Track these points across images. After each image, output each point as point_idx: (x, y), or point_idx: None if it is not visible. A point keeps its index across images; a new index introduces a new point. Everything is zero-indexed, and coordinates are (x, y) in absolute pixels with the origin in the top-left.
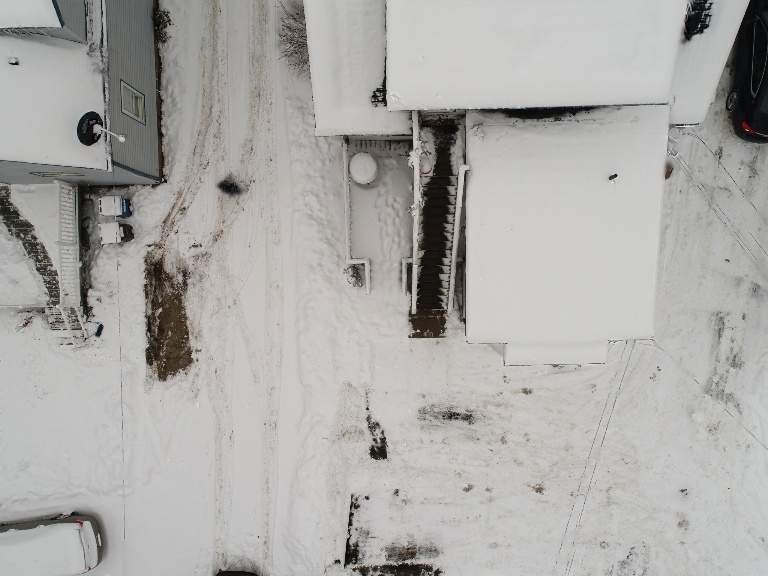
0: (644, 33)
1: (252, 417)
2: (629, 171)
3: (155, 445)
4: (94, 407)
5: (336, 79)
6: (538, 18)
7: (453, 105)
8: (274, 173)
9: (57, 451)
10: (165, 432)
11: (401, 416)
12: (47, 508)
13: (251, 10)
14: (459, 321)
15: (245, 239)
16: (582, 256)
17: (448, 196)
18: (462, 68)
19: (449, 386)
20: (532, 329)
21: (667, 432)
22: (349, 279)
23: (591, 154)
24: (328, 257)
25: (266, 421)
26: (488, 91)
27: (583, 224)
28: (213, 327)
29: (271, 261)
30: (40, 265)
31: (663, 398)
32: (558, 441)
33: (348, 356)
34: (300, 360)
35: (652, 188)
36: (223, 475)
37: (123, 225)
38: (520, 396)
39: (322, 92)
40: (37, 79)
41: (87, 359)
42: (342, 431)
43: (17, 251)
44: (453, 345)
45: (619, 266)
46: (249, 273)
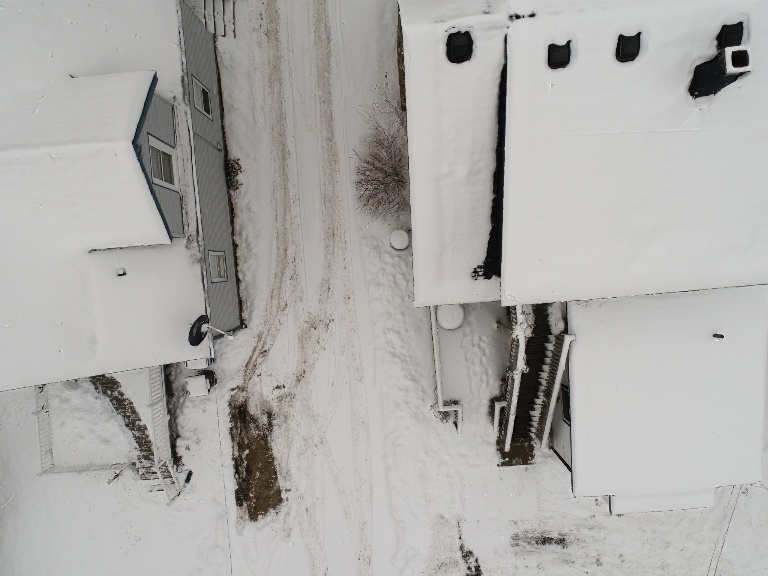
0: (761, 224)
1: (346, 553)
2: (734, 329)
3: None
4: (187, 551)
5: (439, 262)
6: (655, 218)
7: (568, 299)
8: (353, 311)
9: None
10: (260, 573)
11: (494, 544)
12: None
13: (320, 151)
14: (548, 449)
15: (328, 378)
16: (688, 410)
17: (544, 350)
18: (579, 267)
19: (541, 512)
20: (639, 481)
21: (762, 545)
22: (436, 415)
23: (694, 314)
24: (413, 393)
25: (360, 556)
26: (604, 285)
27: (688, 380)
28: (301, 467)
29: (355, 398)
30: (128, 420)
31: (756, 512)
32: (653, 560)
33: (438, 488)
34: (391, 496)
35: (757, 343)
36: None
37: (208, 375)
38: (613, 518)
39: (424, 274)
40: (143, 285)
41: (177, 503)
42: (438, 565)
43: (105, 409)
44: (543, 472)
45: (726, 418)
46: (334, 411)
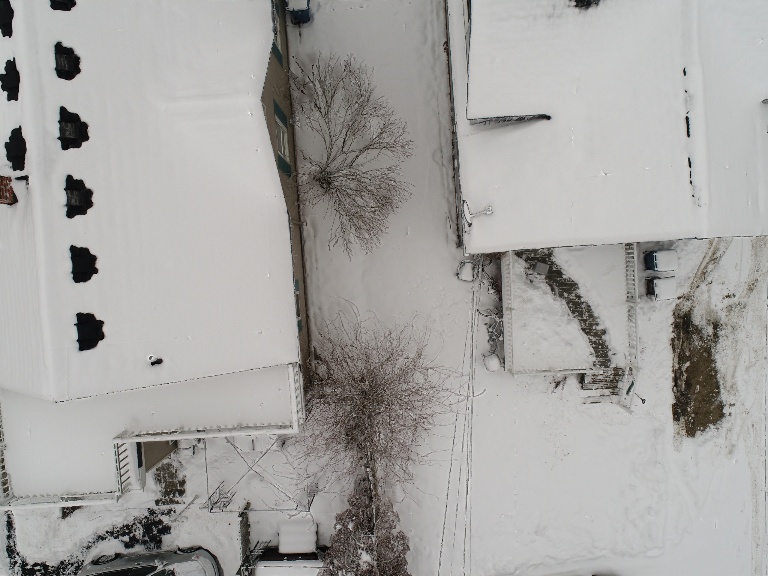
0: None
1: None
2: None
3: (688, 504)
4: (618, 467)
5: None
6: None
7: None
8: None
9: (578, 513)
10: (702, 491)
11: None
12: (566, 572)
13: None
14: None
15: None
16: None
17: None
18: None
19: None
20: None
21: None
22: None
23: None
24: None
25: None
26: None
27: None
28: (750, 380)
29: None
30: (585, 325)
31: None
32: None
33: None
34: None
35: None
36: (760, 533)
37: None
38: None
39: None
40: None
41: (608, 417)
42: None
43: (563, 311)
44: None
45: None
46: None
